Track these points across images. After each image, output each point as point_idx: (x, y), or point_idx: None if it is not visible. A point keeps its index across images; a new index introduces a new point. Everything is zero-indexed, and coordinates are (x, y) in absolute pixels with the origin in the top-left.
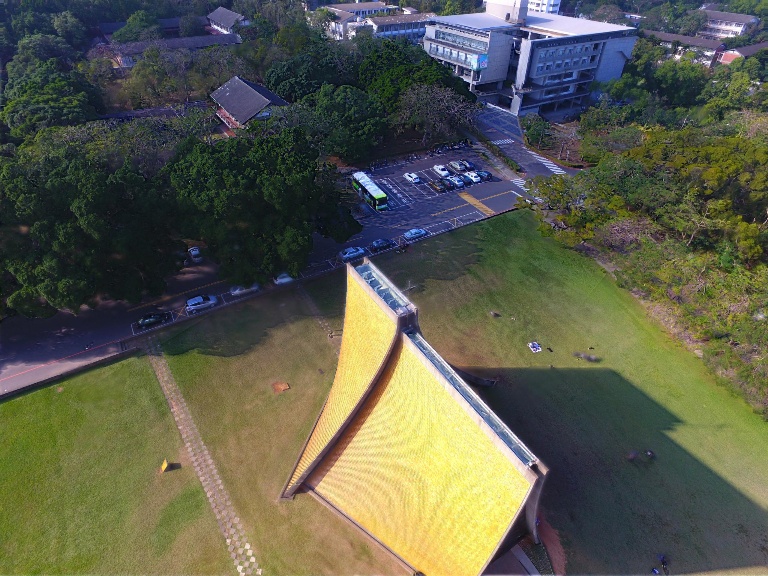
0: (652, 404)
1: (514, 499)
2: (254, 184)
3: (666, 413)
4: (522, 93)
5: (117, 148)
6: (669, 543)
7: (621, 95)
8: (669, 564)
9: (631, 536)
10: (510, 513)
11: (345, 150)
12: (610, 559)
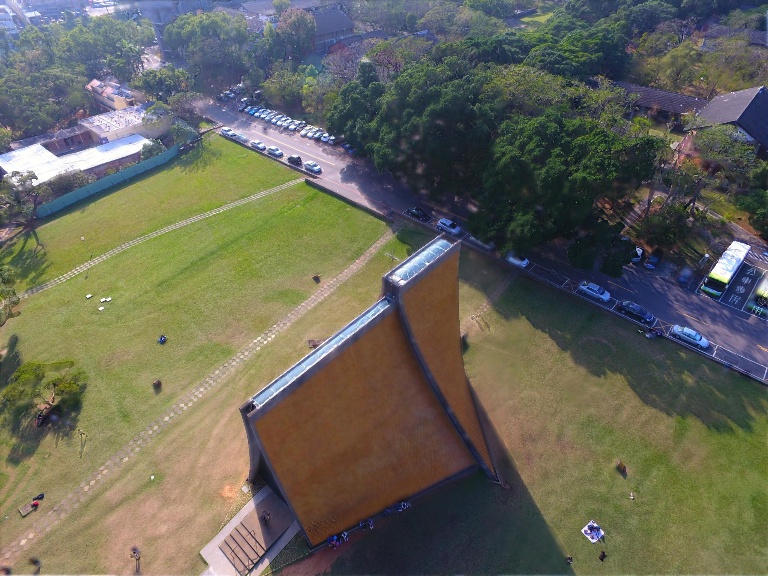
0: None
1: None
2: None
3: None
4: None
5: (504, 88)
6: None
7: None
8: None
9: None
10: None
11: (760, 212)
12: None
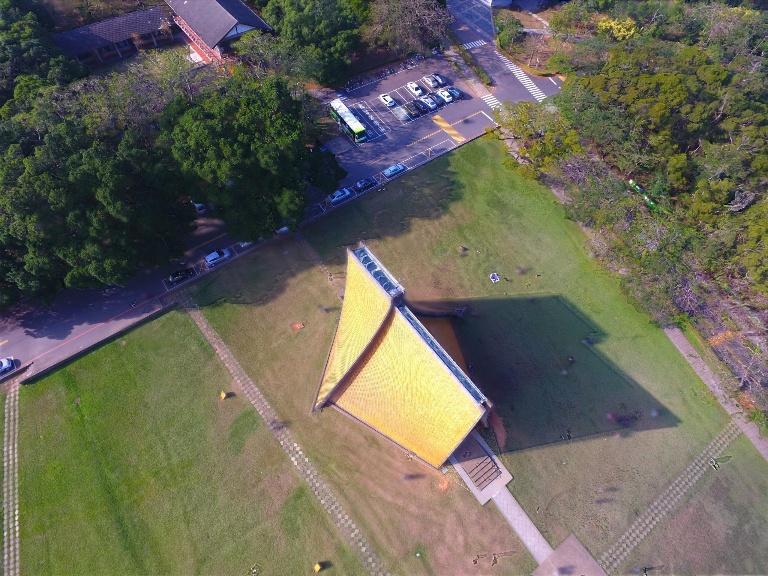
0: (578, 320)
1: (472, 418)
2: (249, 151)
3: (587, 327)
4: None
5: (113, 121)
6: (574, 419)
7: None
8: (572, 432)
9: (550, 417)
10: (469, 425)
11: (320, 75)
12: (534, 433)
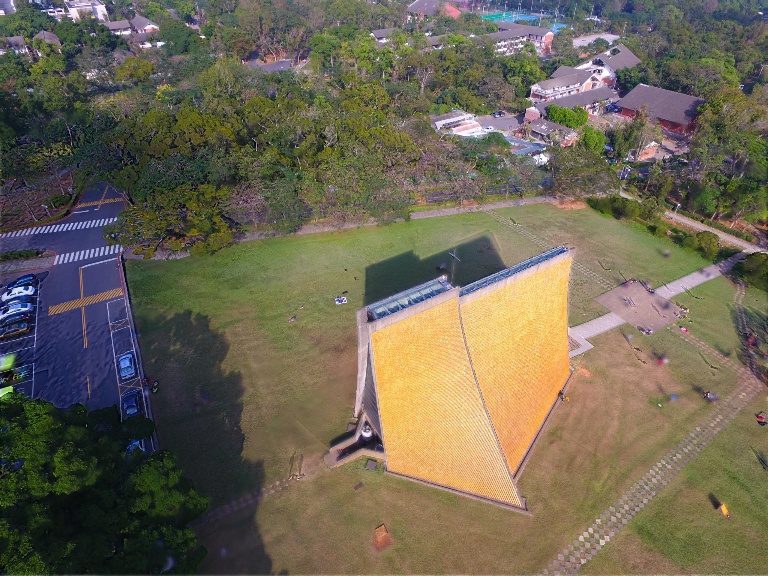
0: (399, 257)
1: (566, 278)
2: (6, 514)
3: (406, 253)
4: None
5: None
6: None
7: None
8: None
9: None
10: (566, 289)
11: None
12: None
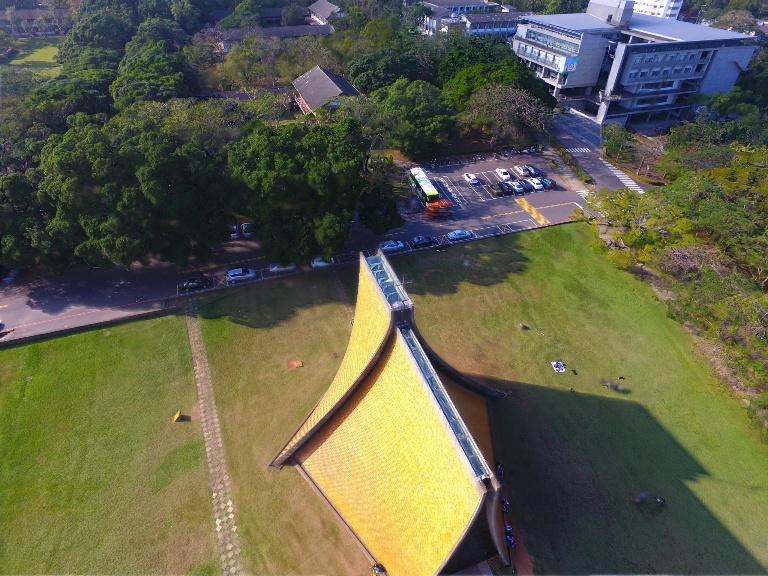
0: (677, 449)
1: (467, 510)
2: (302, 168)
3: (692, 461)
4: (609, 100)
5: (187, 124)
6: None
7: (725, 110)
8: None
9: None
10: (462, 523)
11: (407, 145)
12: None
